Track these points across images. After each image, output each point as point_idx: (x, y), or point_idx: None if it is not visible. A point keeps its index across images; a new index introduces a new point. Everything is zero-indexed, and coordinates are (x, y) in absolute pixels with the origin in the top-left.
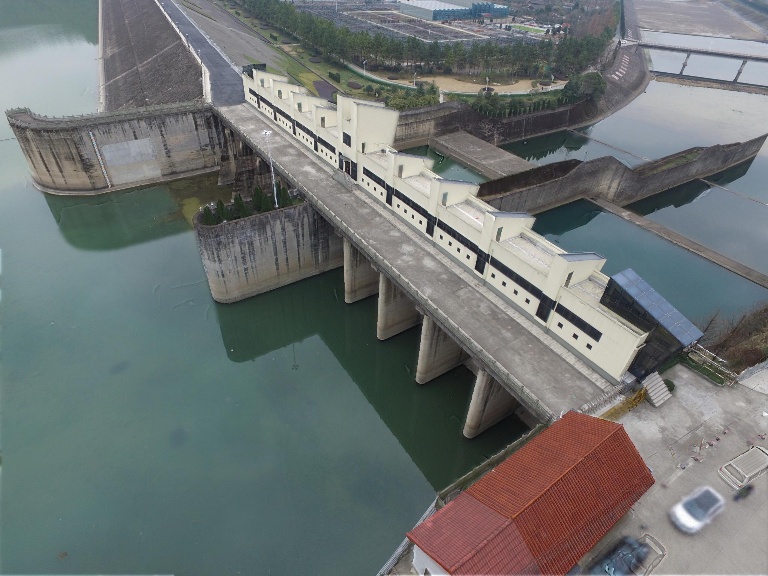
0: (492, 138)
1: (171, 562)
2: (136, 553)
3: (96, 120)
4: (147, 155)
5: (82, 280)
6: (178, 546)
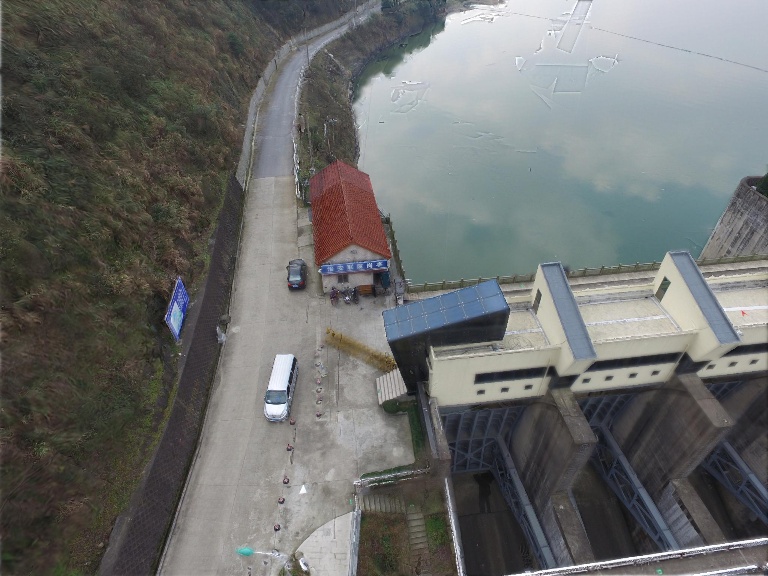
0: None
1: (453, 226)
2: (463, 217)
3: None
4: None
5: (726, 199)
6: (460, 228)
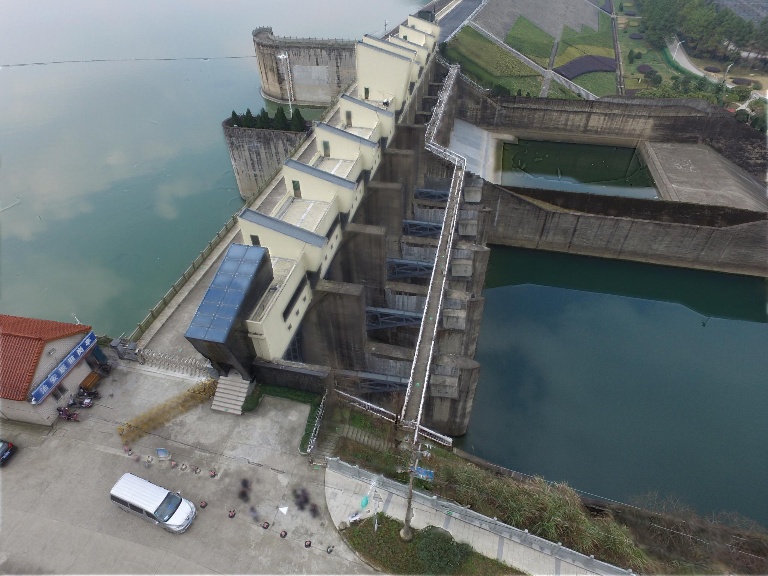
0: (763, 169)
1: (32, 309)
2: (32, 295)
3: (292, 43)
4: (323, 81)
5: (207, 152)
6: (44, 305)
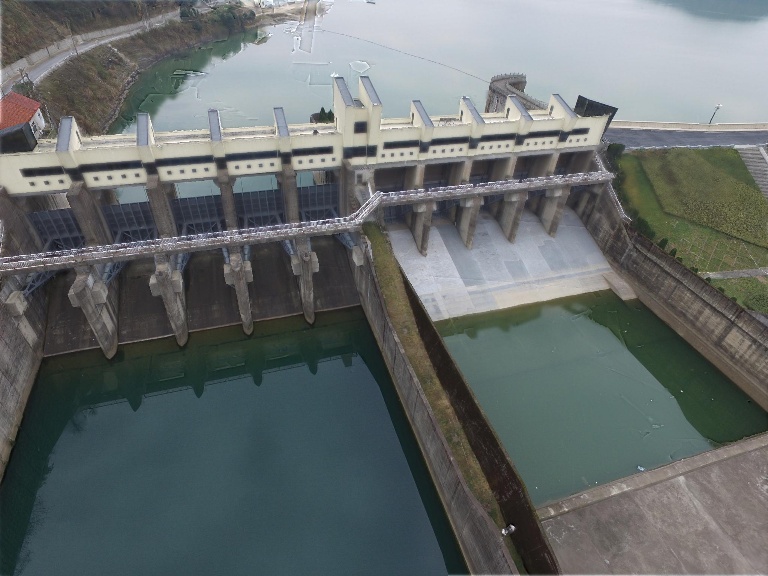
0: None
1: None
2: None
3: None
4: None
5: None
6: None
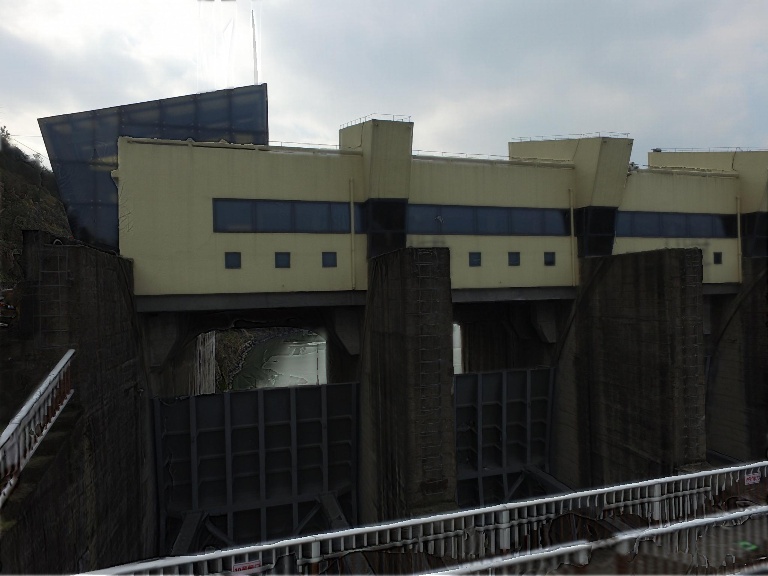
0: None
1: None
2: None
3: None
4: None
5: None
6: None
